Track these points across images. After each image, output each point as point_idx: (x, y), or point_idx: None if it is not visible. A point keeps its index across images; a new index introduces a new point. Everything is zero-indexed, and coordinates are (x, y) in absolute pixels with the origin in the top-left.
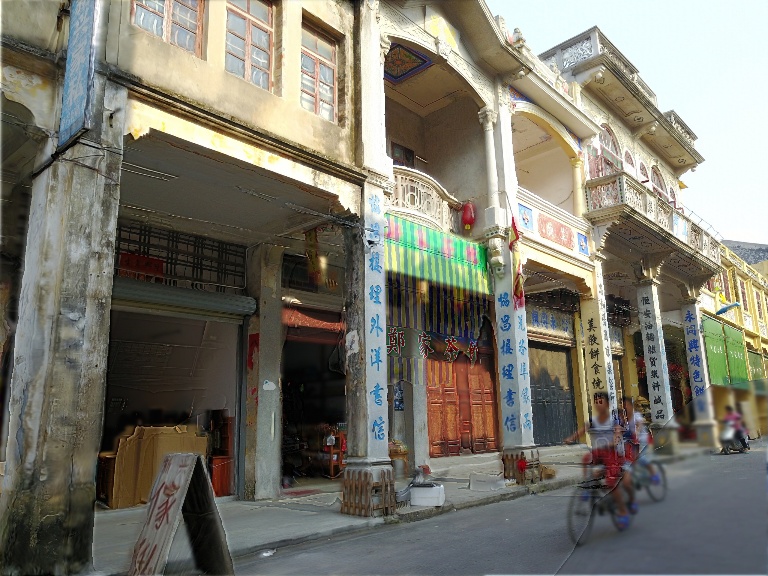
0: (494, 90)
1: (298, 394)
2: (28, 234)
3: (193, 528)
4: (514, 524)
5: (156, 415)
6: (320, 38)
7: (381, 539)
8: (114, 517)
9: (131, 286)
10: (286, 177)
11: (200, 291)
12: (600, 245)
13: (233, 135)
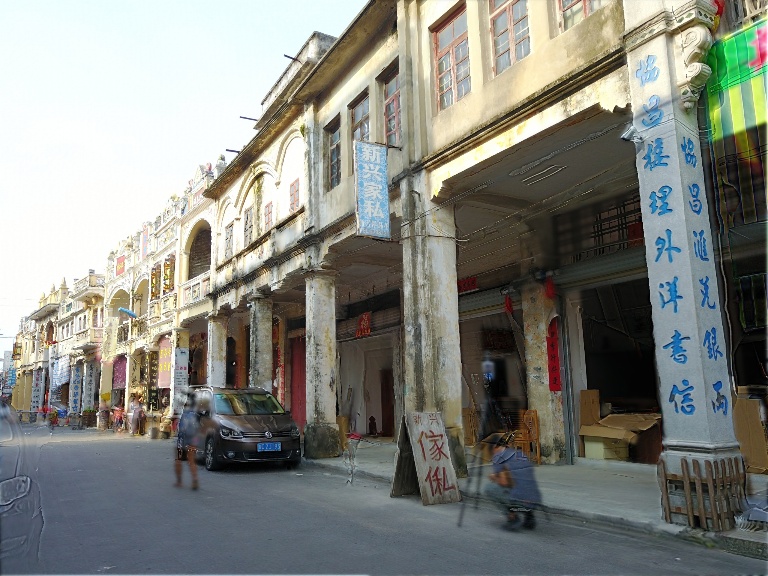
0: None
1: None
2: None
3: None
4: None
5: None
6: None
7: (576, 535)
8: (652, 471)
9: (619, 258)
10: (540, 133)
11: None
12: None
13: (487, 138)
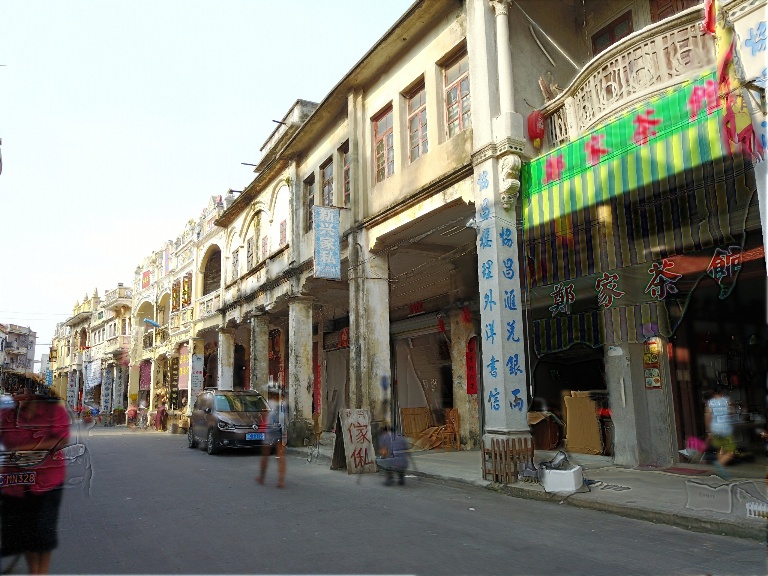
0: None
1: (747, 349)
2: None
3: (338, 443)
4: (438, 507)
5: (578, 382)
6: None
7: None
8: None
9: None
10: (431, 211)
11: None
12: None
13: None
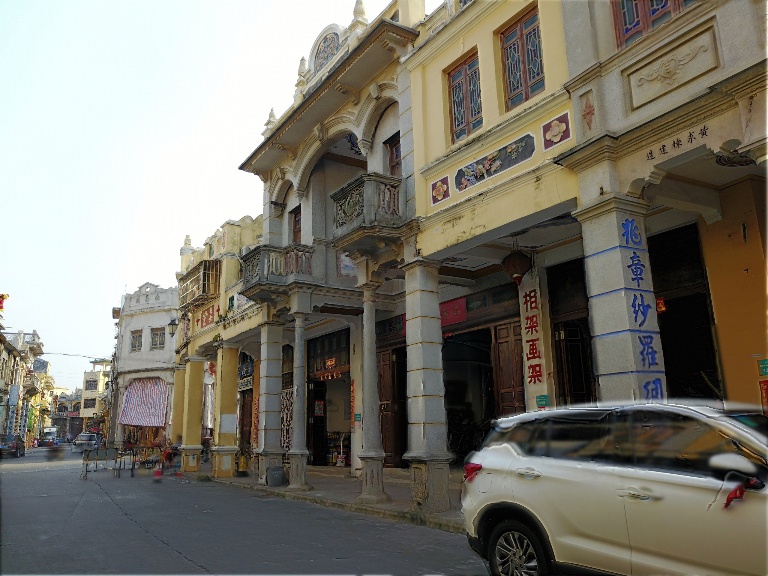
0: (20, 361)
1: None
2: None
3: None
4: None
5: None
6: None
7: None
8: None
9: None
10: None
11: None
12: (24, 393)
13: None
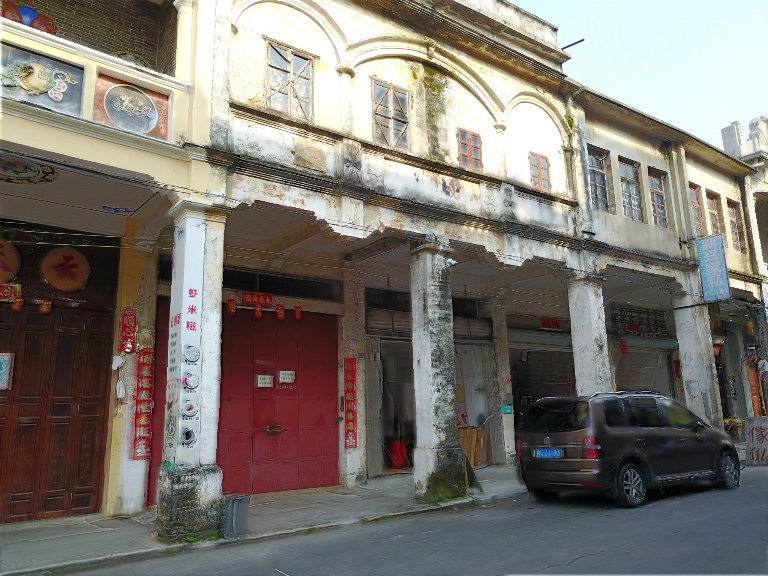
0: None
1: None
2: (678, 332)
3: None
4: None
5: None
6: (728, 207)
7: None
8: None
9: (640, 340)
10: (737, 288)
11: (656, 338)
12: None
13: None
